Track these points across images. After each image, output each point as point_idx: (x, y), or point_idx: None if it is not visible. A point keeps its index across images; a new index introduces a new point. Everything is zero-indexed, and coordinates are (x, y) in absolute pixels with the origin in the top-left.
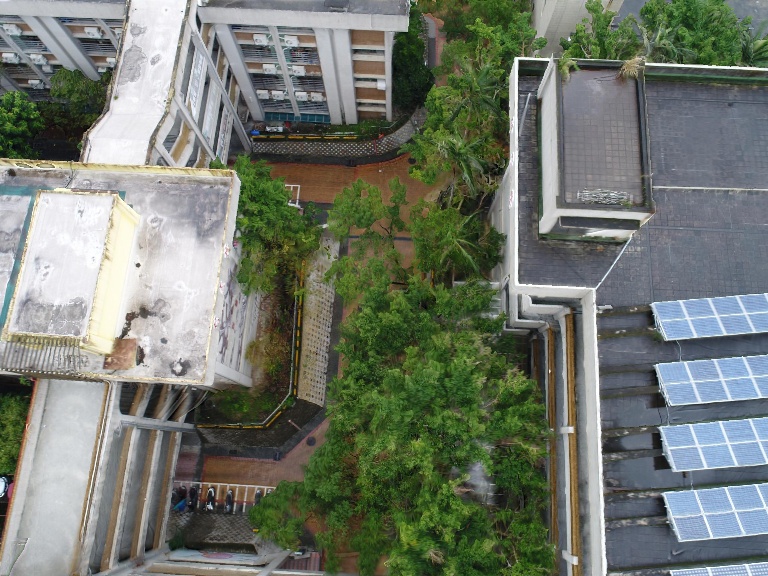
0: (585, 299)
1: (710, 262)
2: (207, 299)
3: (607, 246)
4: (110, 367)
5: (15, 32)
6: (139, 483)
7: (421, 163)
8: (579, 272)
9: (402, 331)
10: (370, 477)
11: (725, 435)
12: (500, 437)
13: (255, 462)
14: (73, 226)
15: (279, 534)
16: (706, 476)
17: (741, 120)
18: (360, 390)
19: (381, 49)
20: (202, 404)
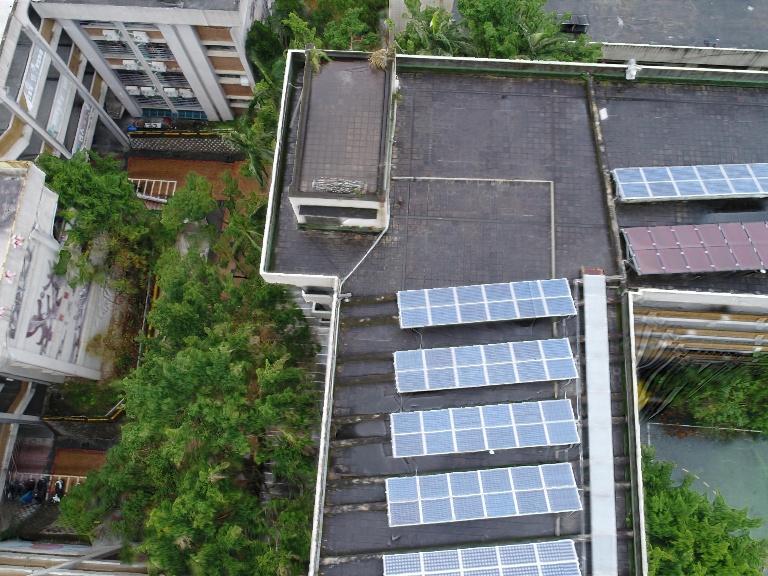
0: None
1: (464, 252)
2: None
3: (365, 236)
4: None
5: None
6: None
7: None
8: (334, 261)
9: (196, 321)
10: None
11: (452, 422)
12: (263, 425)
13: None
14: None
15: None
16: (430, 462)
17: (512, 112)
18: (148, 380)
19: (231, 45)
20: (51, 397)
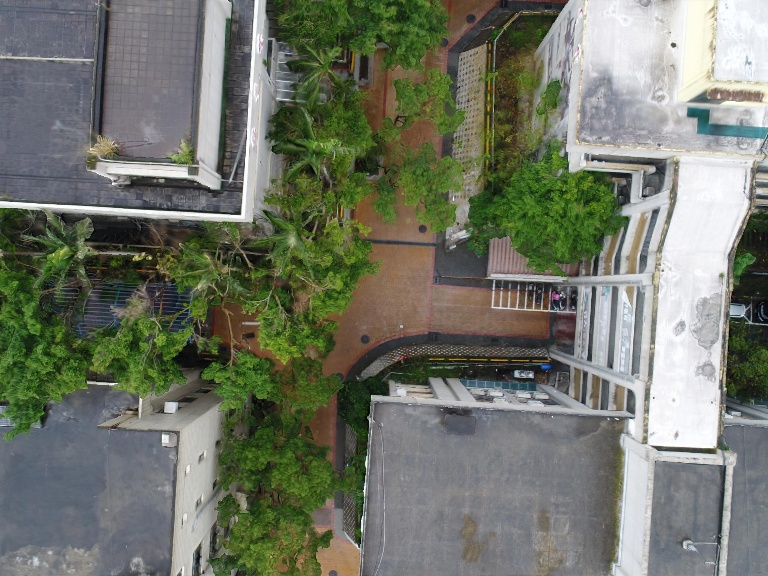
0: None
1: None
2: (595, 5)
3: None
4: None
5: None
6: None
7: None
8: None
9: None
10: None
11: None
12: None
13: None
14: (755, 45)
15: None
16: None
17: None
18: None
19: None
20: None
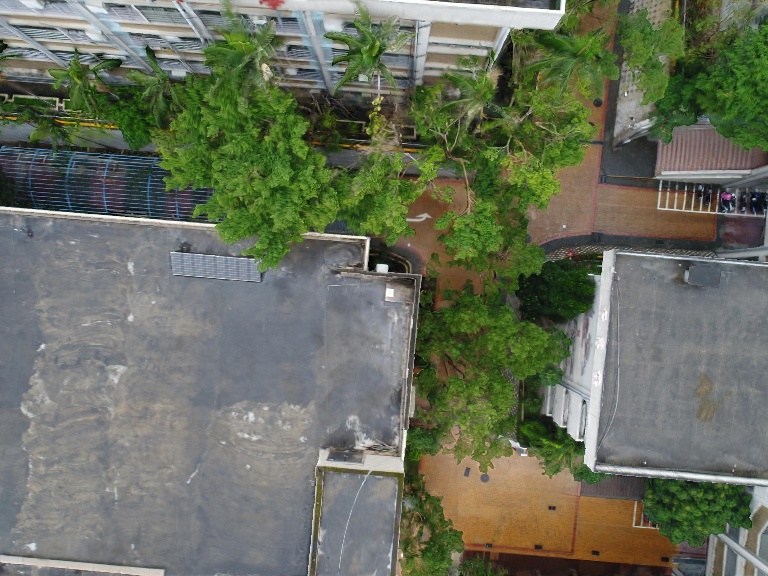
0: None
1: None
2: None
3: None
4: None
5: None
6: None
7: None
8: None
9: None
10: None
11: None
12: None
13: None
14: None
15: None
16: None
17: None
18: None
19: None
20: None
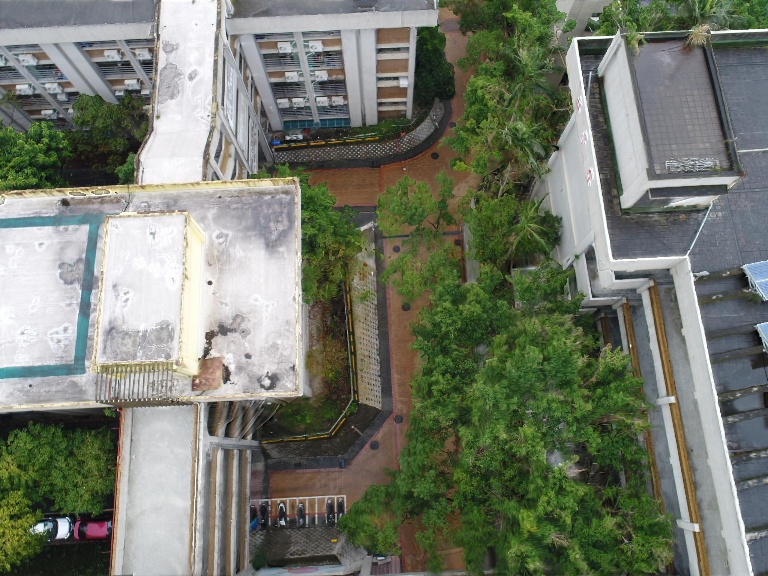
0: (677, 268)
1: None
2: (286, 310)
3: (689, 214)
4: (199, 388)
5: (31, 62)
6: (224, 505)
7: (462, 155)
8: (666, 243)
9: (481, 321)
10: (465, 471)
11: None
12: (603, 415)
13: (321, 472)
14: (147, 249)
15: (356, 542)
16: None
17: None
18: (448, 385)
19: (406, 46)
20: None
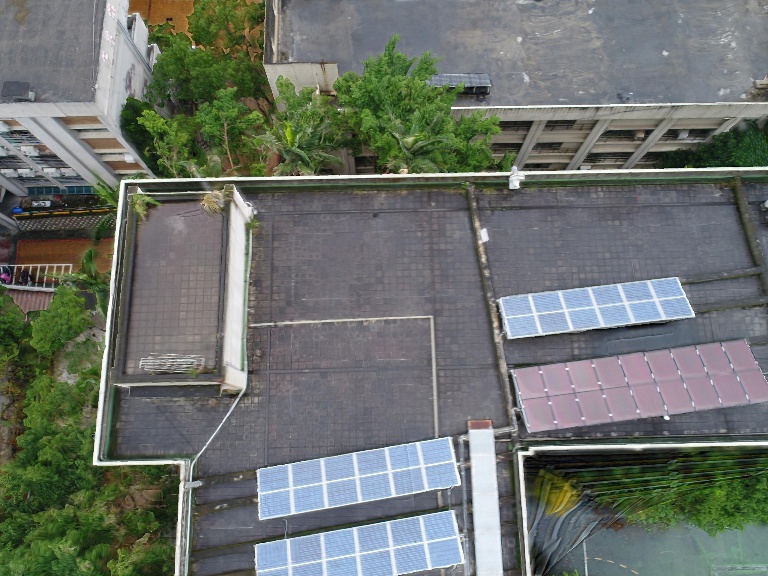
0: None
1: (335, 410)
2: None
3: (220, 399)
4: None
5: None
6: None
7: None
8: (185, 434)
9: (55, 483)
10: None
11: None
12: None
13: None
14: None
15: None
16: None
17: (385, 233)
18: None
19: (103, 127)
20: None
